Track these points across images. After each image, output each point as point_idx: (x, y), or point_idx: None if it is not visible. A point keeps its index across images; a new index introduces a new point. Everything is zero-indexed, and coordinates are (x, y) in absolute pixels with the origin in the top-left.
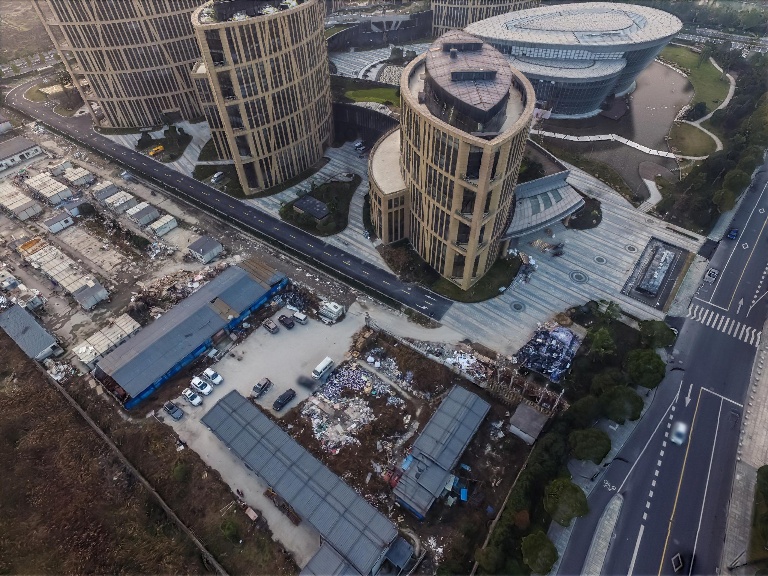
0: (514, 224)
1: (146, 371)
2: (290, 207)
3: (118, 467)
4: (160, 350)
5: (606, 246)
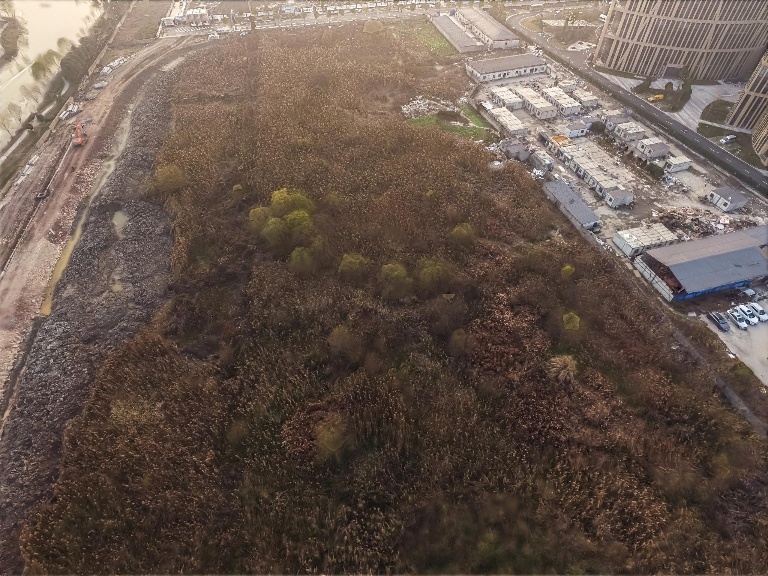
0: None
1: (699, 277)
2: None
3: (674, 341)
4: (712, 266)
5: None
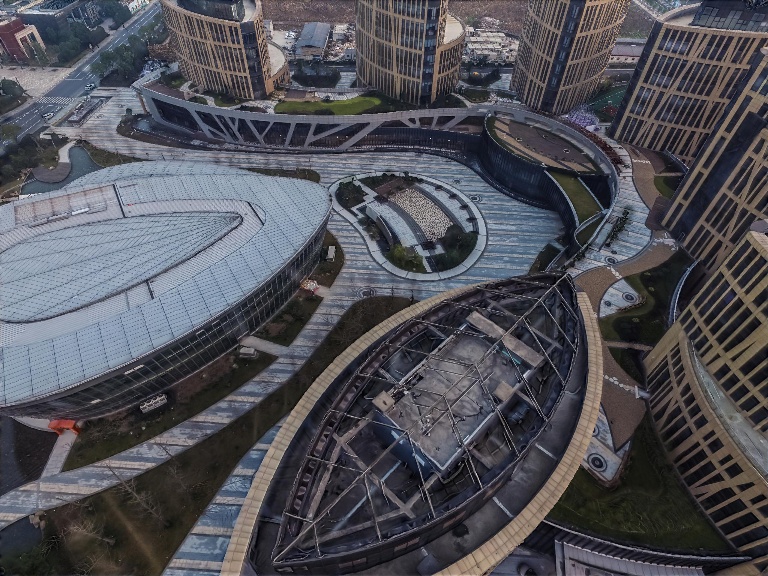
0: (176, 65)
1: None
2: (336, 75)
3: None
4: None
5: (118, 113)
